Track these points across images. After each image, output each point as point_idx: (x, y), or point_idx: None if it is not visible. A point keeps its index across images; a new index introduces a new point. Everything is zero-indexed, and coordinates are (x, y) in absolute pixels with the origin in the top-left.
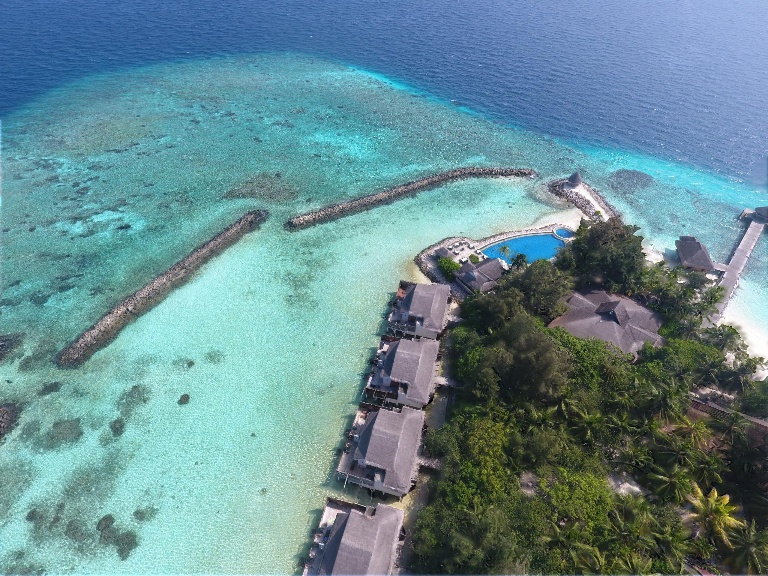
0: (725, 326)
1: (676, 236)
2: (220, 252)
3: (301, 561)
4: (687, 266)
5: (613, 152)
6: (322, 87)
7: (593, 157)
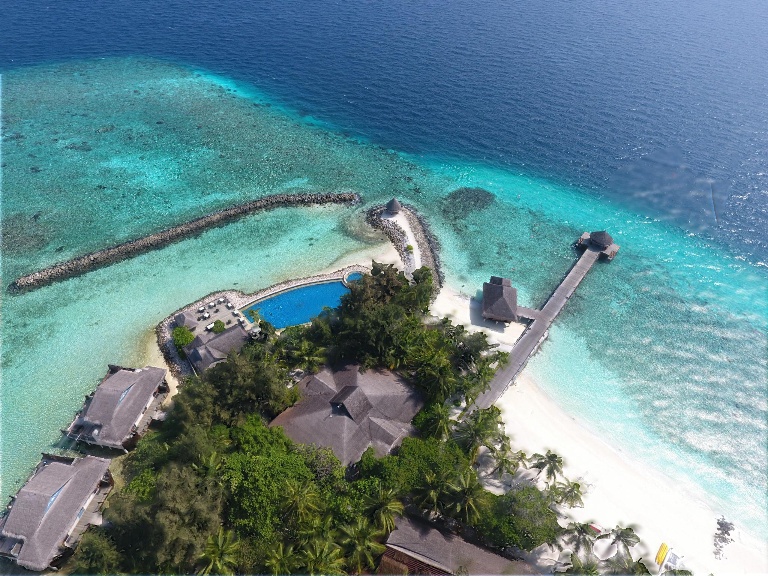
0: (479, 416)
1: (497, 272)
2: None
3: None
4: (488, 317)
5: (459, 166)
6: (150, 98)
7: (436, 173)
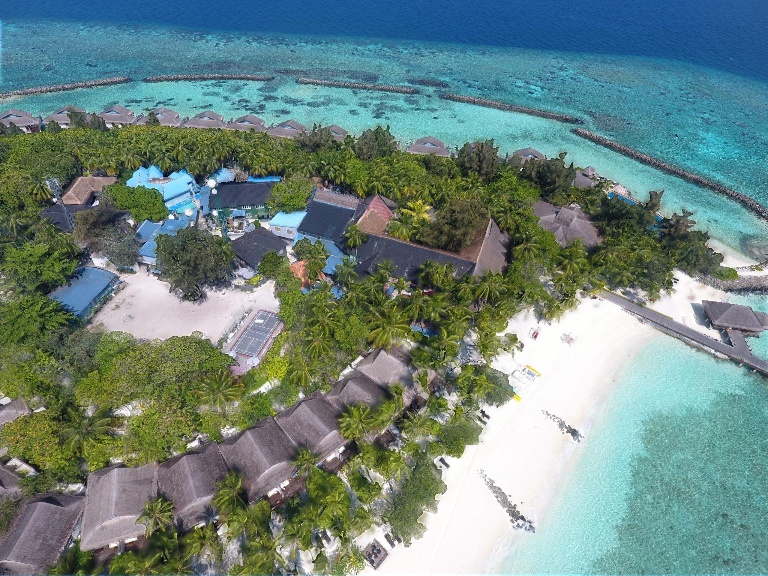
0: None
1: None
2: (532, 115)
3: None
4: None
5: None
6: None
7: None
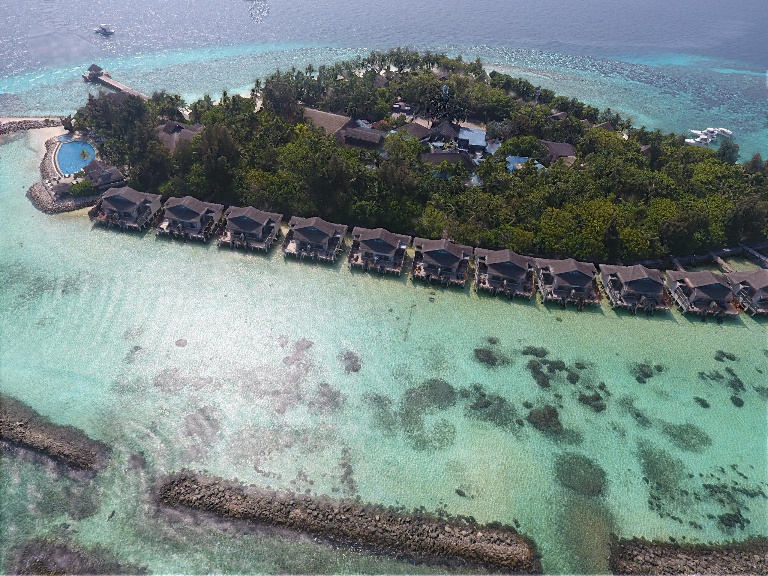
0: (200, 100)
1: None
2: None
3: (314, 263)
4: None
5: None
6: None
7: None
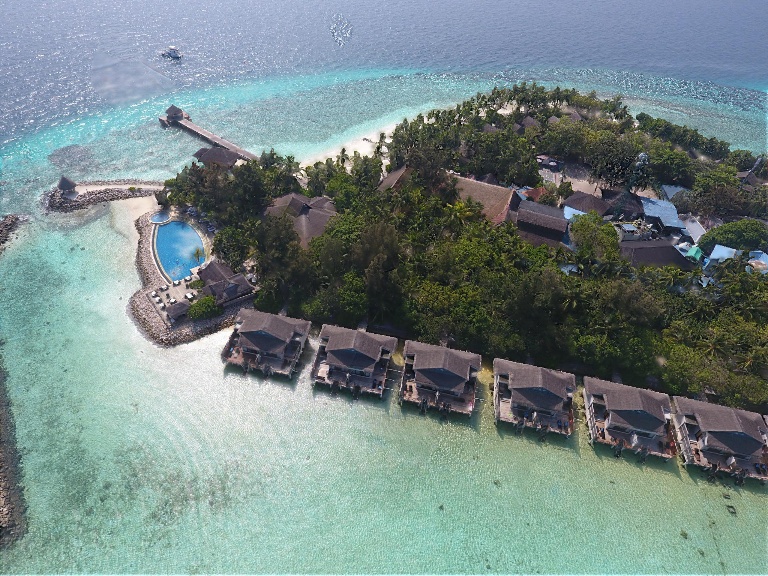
0: (320, 163)
1: (179, 161)
2: None
3: (542, 439)
4: None
5: (9, 151)
6: None
7: (6, 167)
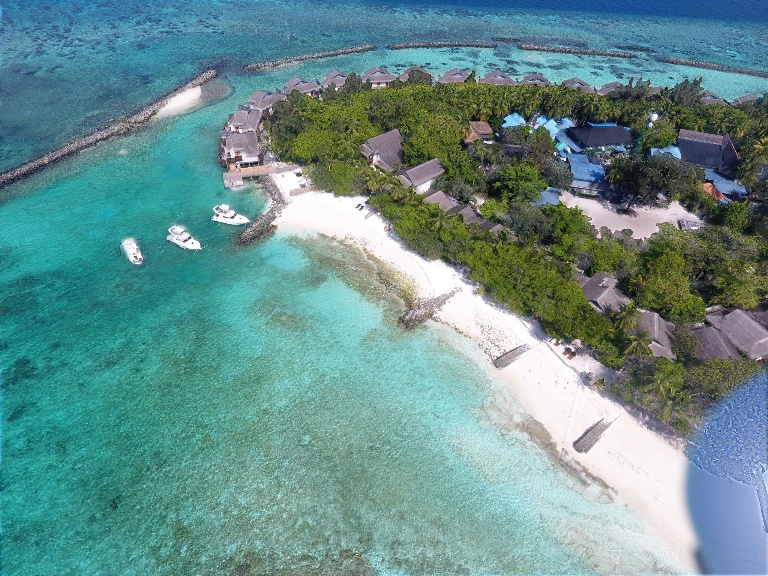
0: None
1: None
2: (752, 75)
3: None
4: None
5: None
6: None
7: None
